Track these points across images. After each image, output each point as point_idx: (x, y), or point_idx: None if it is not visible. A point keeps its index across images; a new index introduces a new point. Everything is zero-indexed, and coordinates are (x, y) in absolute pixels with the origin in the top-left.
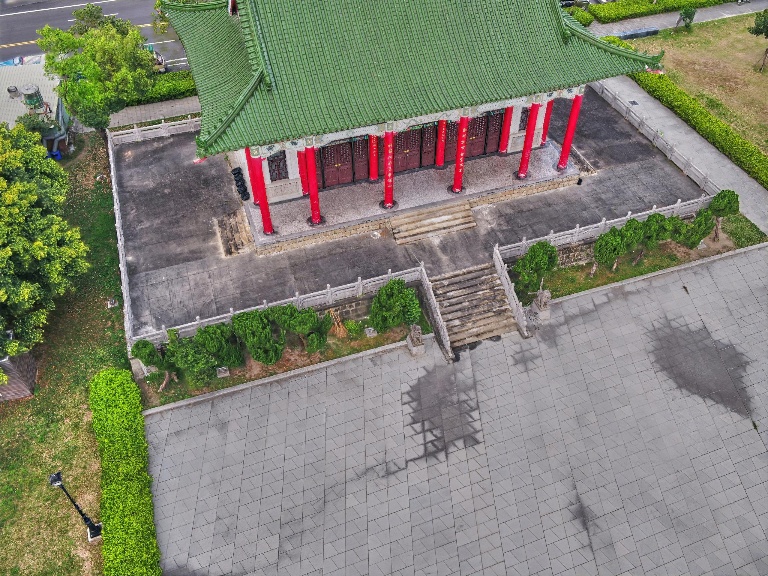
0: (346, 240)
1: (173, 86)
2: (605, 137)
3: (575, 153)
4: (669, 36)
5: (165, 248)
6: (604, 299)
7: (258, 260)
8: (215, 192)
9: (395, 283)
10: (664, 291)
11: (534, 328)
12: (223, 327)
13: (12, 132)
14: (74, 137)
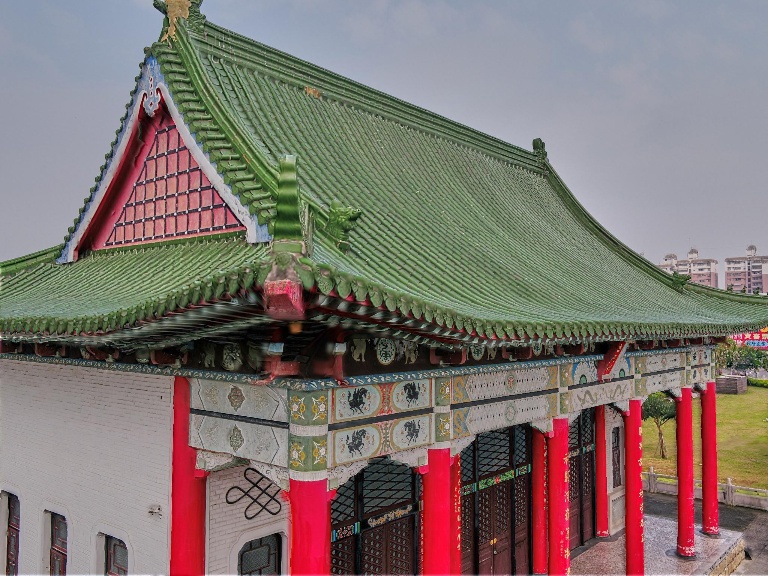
0: None
1: None
2: (666, 510)
3: None
4: None
5: None
6: None
7: None
8: None
9: None
10: None
11: None
12: None
13: None
14: None
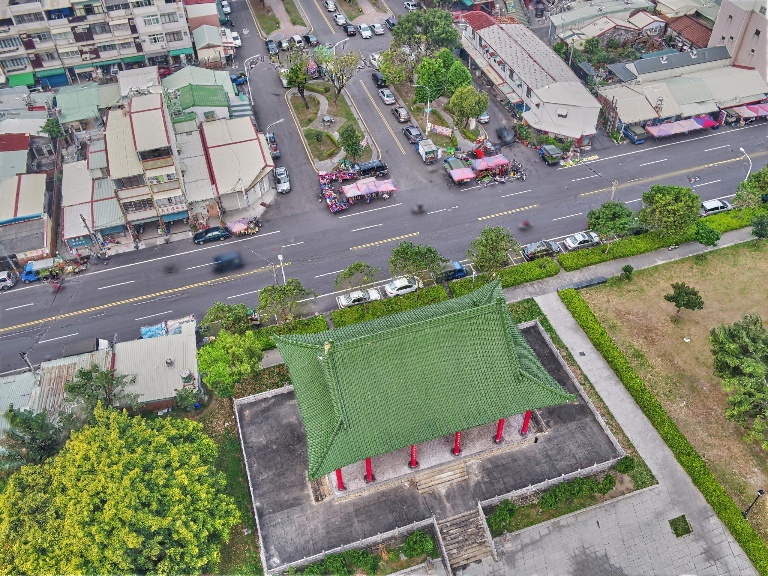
0: (388, 490)
1: (268, 342)
2: None
3: (535, 414)
4: (614, 284)
5: (278, 496)
6: (546, 531)
7: (335, 506)
8: (305, 448)
9: (418, 534)
10: (584, 525)
11: (502, 554)
12: (320, 567)
13: (189, 430)
14: (206, 387)
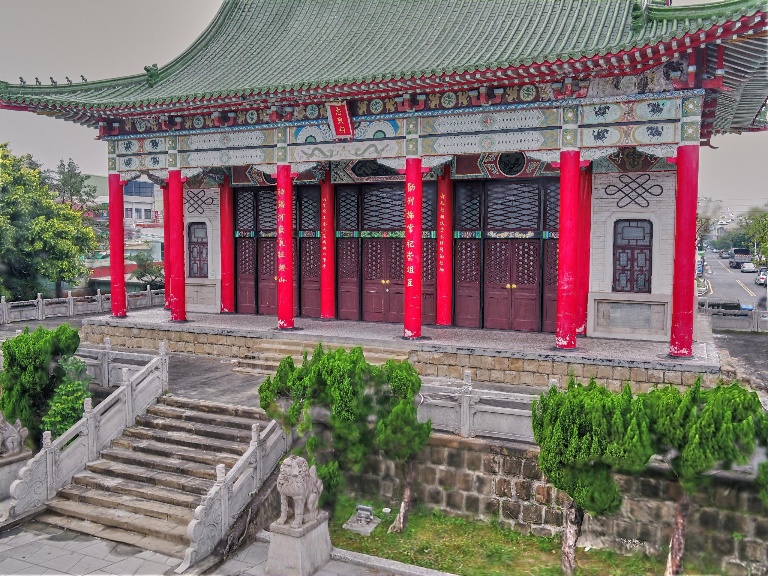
0: (188, 355)
1: None
2: None
3: None
4: None
5: None
6: None
7: None
8: None
9: (59, 331)
10: None
11: None
12: None
13: None
14: None
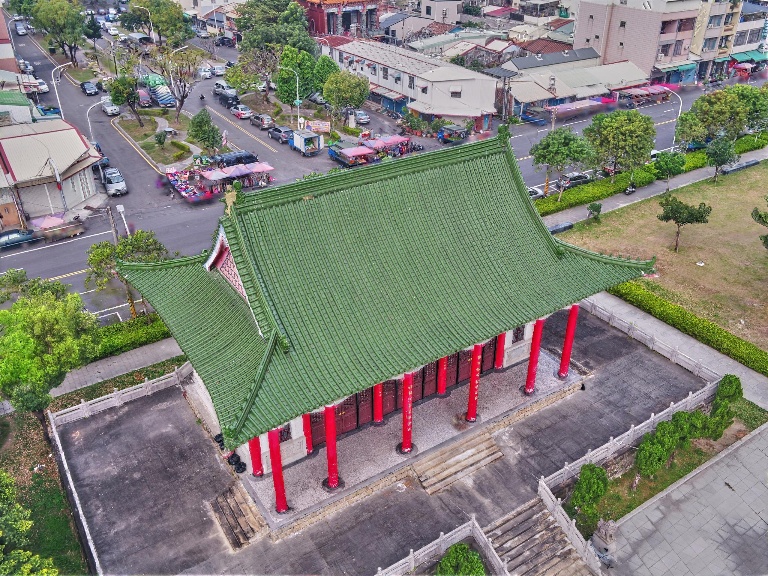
0: (370, 500)
1: (108, 343)
2: (582, 335)
3: None
4: (583, 228)
5: (153, 555)
6: (658, 514)
7: (275, 548)
8: (197, 466)
9: (457, 550)
10: (710, 492)
11: (606, 567)
12: None
13: None
14: None
